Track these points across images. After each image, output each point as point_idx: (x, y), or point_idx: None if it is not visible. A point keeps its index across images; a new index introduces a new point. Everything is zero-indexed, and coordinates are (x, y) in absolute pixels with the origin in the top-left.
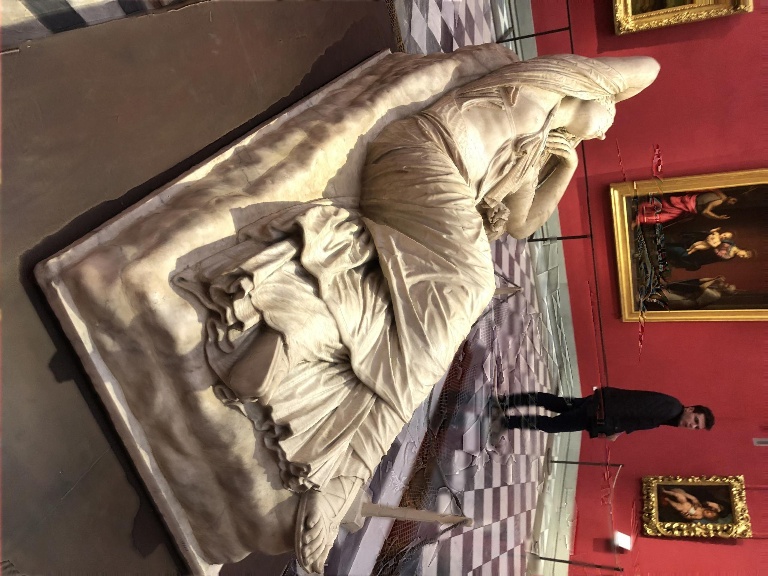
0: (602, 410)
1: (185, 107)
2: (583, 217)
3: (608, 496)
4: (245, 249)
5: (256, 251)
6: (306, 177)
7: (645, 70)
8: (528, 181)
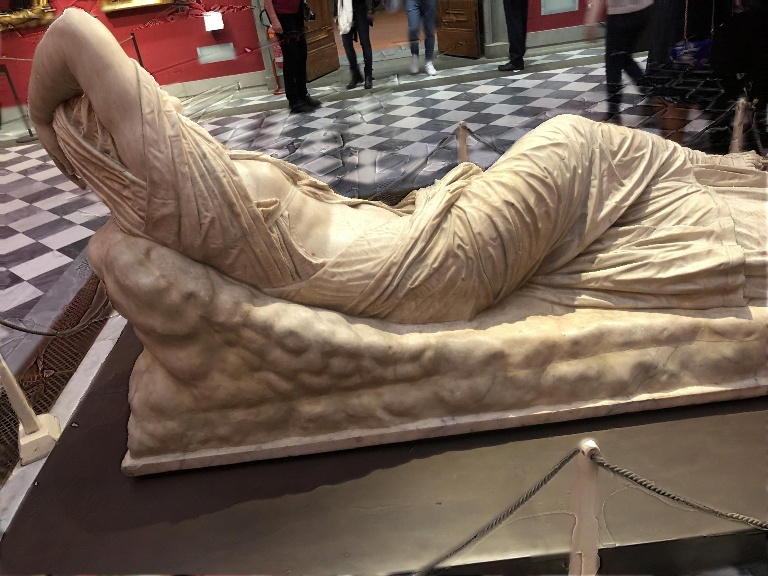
0: (277, 44)
1: (668, 457)
2: (30, 125)
3: (344, 23)
4: (759, 288)
5: (753, 280)
6: None
7: (104, 31)
8: None
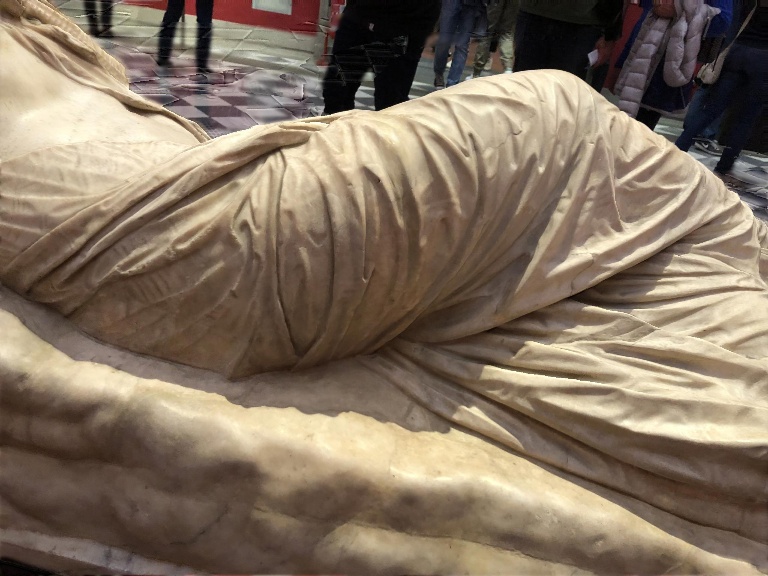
0: None
1: None
2: None
3: None
4: None
5: None
6: (498, 479)
7: None
8: None
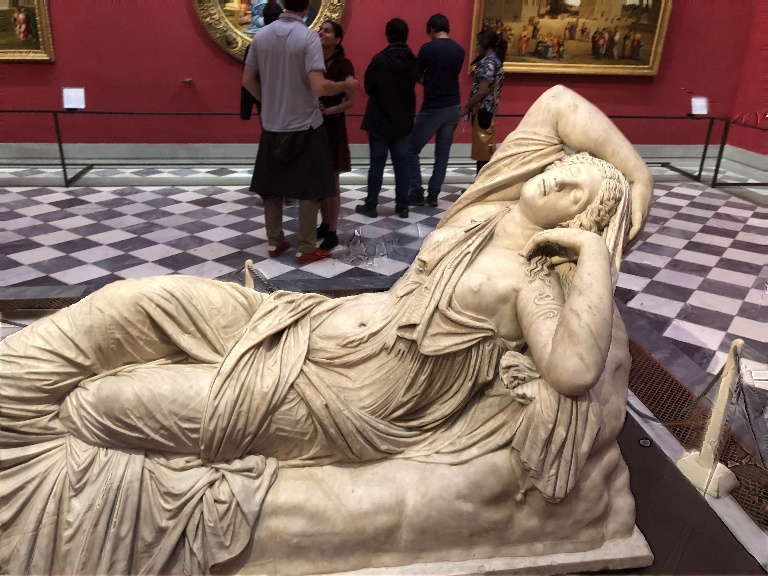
0: None
1: None
2: None
3: None
4: None
5: None
6: None
7: None
8: (468, 289)
